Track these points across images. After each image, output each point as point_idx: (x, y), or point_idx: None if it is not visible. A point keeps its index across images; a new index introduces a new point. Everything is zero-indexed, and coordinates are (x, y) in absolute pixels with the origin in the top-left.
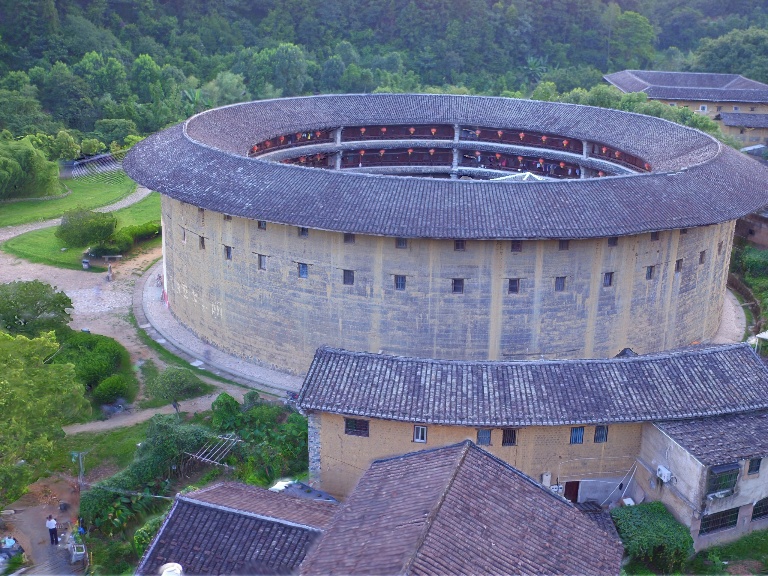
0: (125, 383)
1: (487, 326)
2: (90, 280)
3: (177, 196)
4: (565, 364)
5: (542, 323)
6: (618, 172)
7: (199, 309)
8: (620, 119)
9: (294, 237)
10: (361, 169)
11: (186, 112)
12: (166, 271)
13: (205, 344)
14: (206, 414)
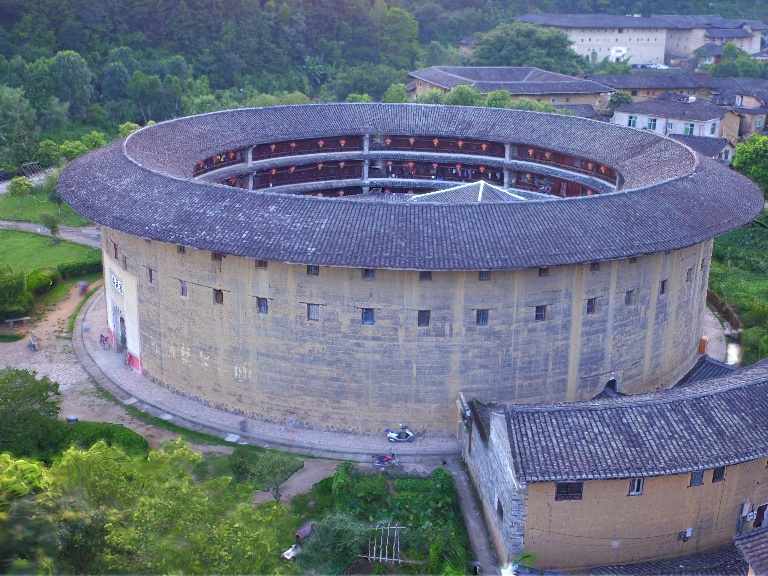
0: None
1: (567, 351)
2: (10, 353)
3: (208, 246)
4: (746, 386)
5: (614, 340)
6: (552, 173)
7: (212, 373)
8: (537, 120)
9: (357, 280)
10: (272, 189)
11: (4, 136)
12: (139, 332)
13: (223, 413)
14: (302, 499)
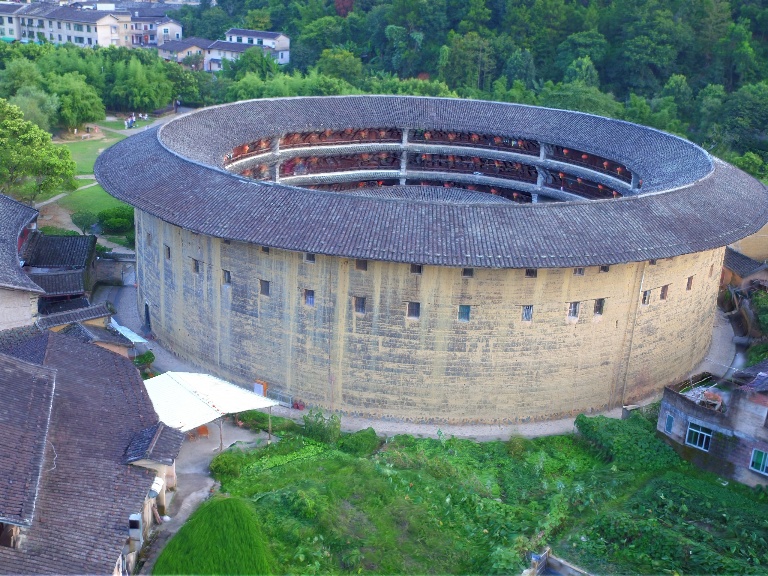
0: (122, 224)
1: None
2: None
3: None
4: None
5: None
6: None
7: None
8: None
9: None
10: (562, 193)
11: None
12: None
13: None
14: None
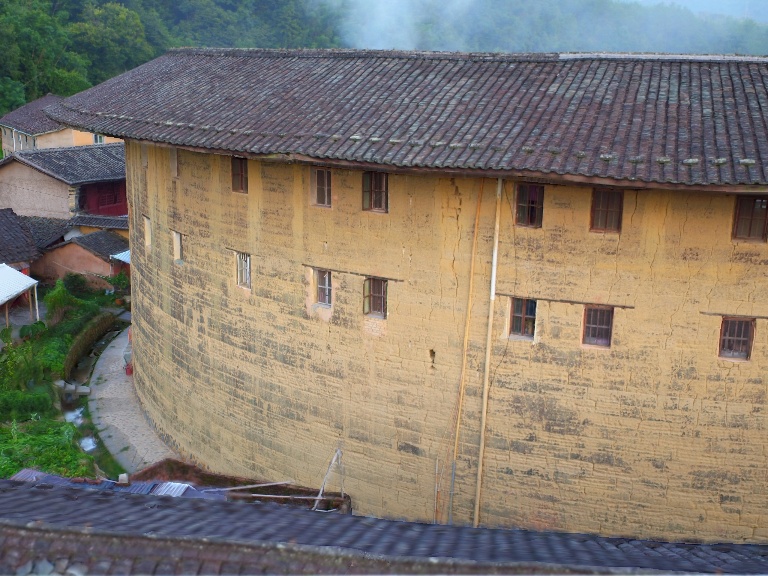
0: None
1: None
2: None
3: None
4: None
5: None
6: None
7: None
8: None
9: None
10: None
11: None
12: None
13: None
14: None
